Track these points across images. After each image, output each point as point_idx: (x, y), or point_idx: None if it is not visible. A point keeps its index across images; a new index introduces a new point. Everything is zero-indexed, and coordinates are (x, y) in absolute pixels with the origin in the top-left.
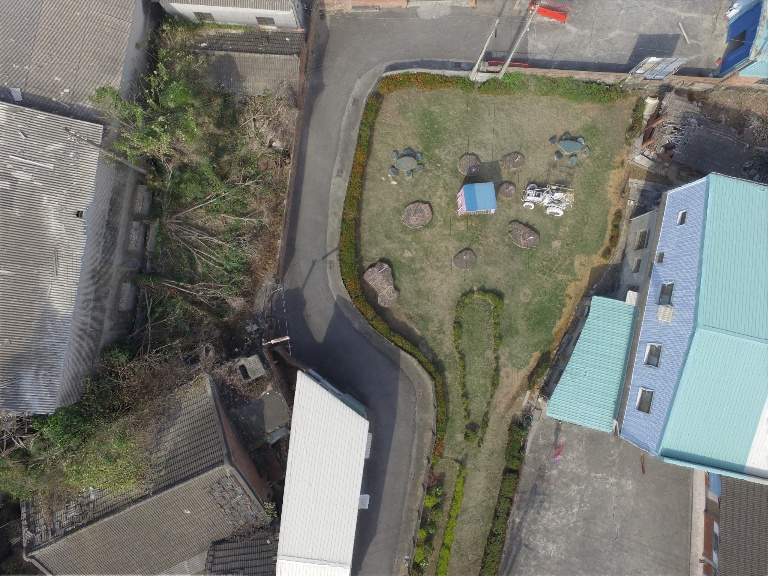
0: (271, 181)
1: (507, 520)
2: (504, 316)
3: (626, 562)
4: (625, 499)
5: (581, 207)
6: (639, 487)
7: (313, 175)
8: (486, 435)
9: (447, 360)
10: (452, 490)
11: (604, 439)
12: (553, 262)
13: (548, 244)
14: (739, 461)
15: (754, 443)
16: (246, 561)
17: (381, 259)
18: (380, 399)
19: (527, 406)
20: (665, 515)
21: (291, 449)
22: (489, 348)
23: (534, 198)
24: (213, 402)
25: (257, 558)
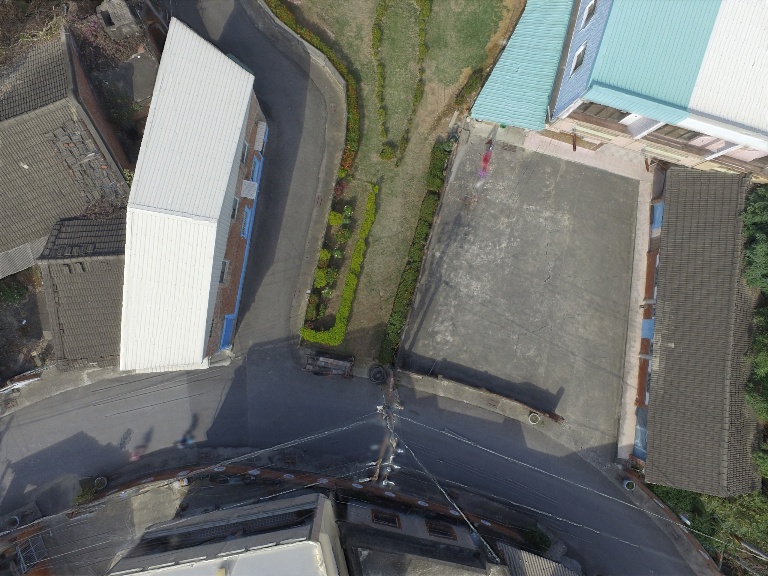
0: None
1: (424, 246)
2: (432, 25)
3: (558, 305)
4: (560, 235)
5: None
6: (576, 223)
7: None
8: (406, 157)
9: (364, 69)
10: (364, 216)
11: (539, 168)
12: None
13: None
14: (680, 102)
15: (698, 80)
16: (99, 236)
17: None
18: (284, 110)
19: (454, 127)
20: (604, 256)
21: (155, 95)
22: (413, 59)
23: None
24: (65, 47)
25: (113, 234)
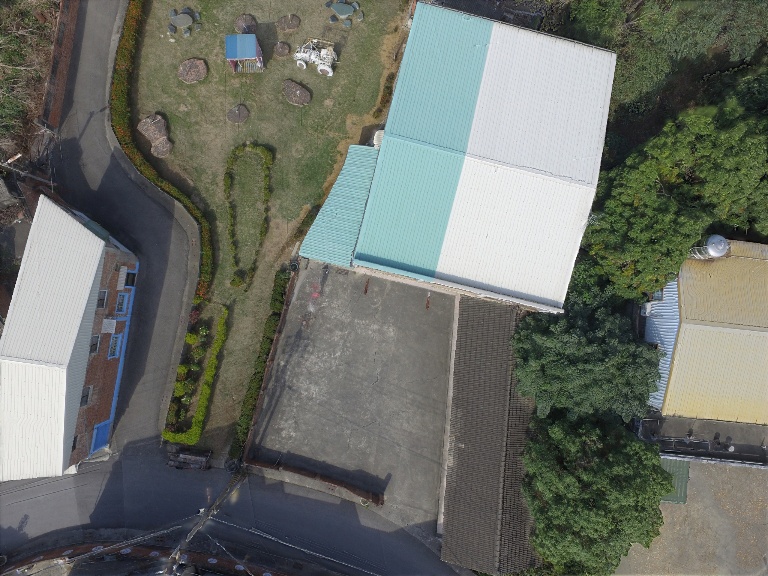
0: (49, 33)
1: (267, 359)
2: (276, 170)
3: (385, 404)
4: (386, 345)
5: (354, 69)
6: (400, 334)
7: (93, 31)
8: (254, 282)
9: (219, 210)
10: None
11: (368, 288)
12: (325, 120)
13: (321, 103)
14: (430, 267)
15: (443, 249)
16: None
17: (157, 112)
18: (153, 246)
19: (295, 256)
20: (425, 361)
21: (24, 263)
22: (260, 200)
23: (302, 55)
24: None
25: None
